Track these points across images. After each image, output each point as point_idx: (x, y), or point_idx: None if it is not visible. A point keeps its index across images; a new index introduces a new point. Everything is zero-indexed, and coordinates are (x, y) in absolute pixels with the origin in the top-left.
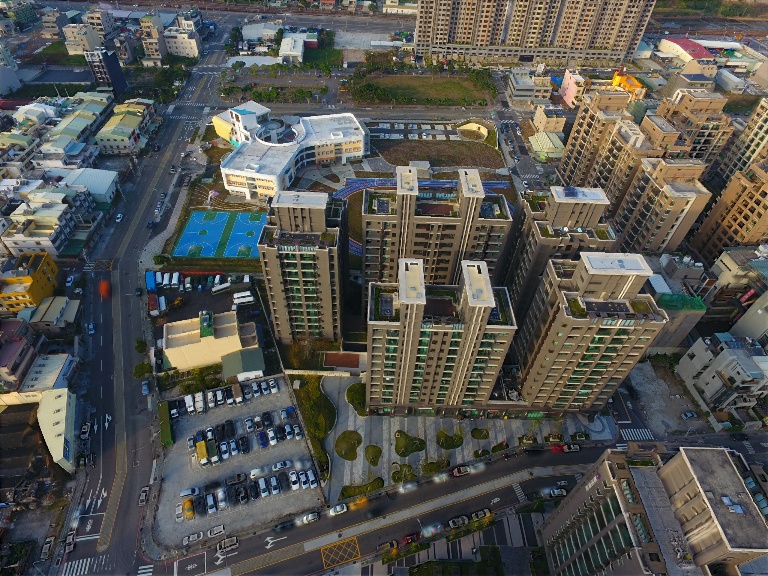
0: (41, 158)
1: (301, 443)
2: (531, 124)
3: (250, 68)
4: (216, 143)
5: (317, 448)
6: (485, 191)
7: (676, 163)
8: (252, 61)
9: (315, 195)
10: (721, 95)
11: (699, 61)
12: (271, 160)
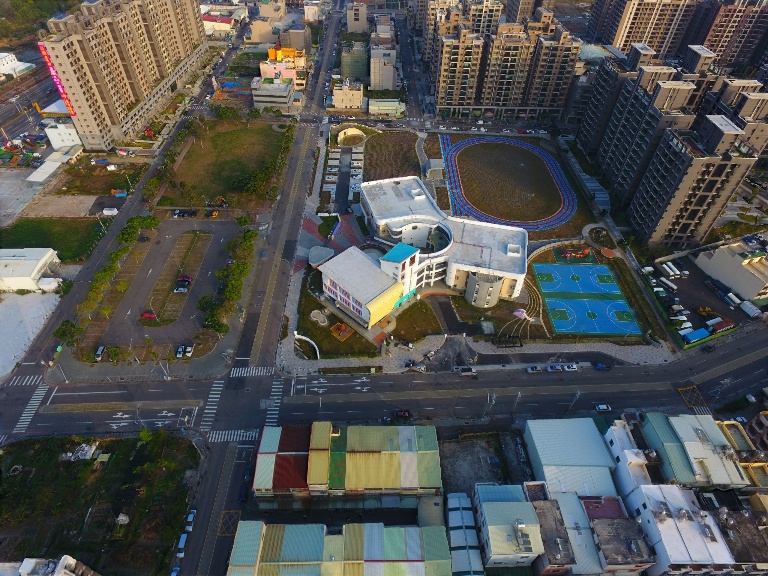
0: (565, 542)
1: (763, 236)
2: (334, 110)
3: (84, 317)
4: (381, 335)
5: (763, 227)
6: (457, 145)
7: (565, 30)
8: (0, 335)
9: (713, 119)
10: (453, 6)
11: (262, 20)
12: (487, 239)
